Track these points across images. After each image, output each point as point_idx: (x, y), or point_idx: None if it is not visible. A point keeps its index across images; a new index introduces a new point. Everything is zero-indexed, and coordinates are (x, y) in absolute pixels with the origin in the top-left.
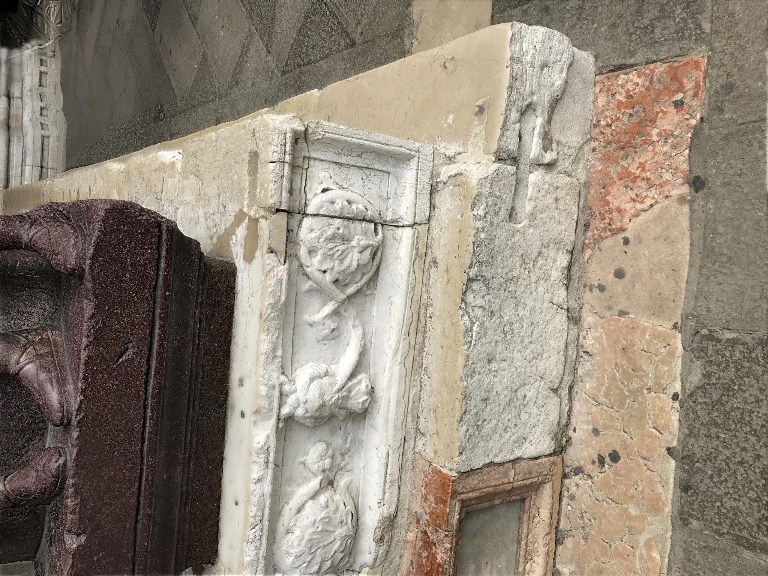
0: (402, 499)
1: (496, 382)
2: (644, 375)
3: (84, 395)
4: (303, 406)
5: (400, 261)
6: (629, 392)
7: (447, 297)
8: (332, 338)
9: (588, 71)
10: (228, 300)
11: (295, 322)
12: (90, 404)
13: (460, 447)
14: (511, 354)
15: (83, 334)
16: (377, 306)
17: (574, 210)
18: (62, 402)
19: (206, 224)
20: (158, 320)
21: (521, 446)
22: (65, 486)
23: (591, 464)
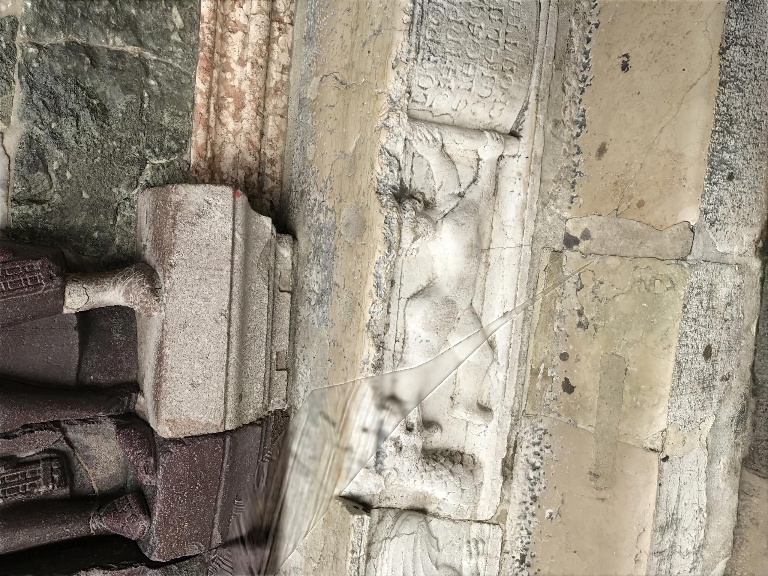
0: None
1: None
2: None
3: None
4: None
5: None
6: None
7: None
8: None
9: None
10: None
11: None
12: None
13: None
14: None
15: None
16: None
17: None
18: None
19: (291, 568)
20: None
21: None
22: None
23: None
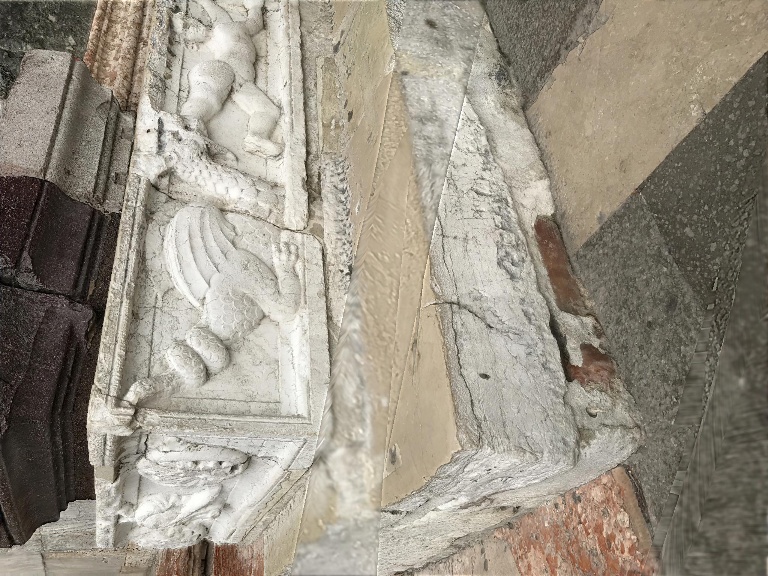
0: (247, 539)
1: None
2: None
3: None
4: None
5: (268, 475)
6: None
7: (297, 523)
8: None
9: (604, 463)
10: None
11: (141, 483)
12: None
13: None
14: None
15: None
16: (240, 480)
17: (494, 522)
18: None
19: None
20: None
21: None
22: None
23: None
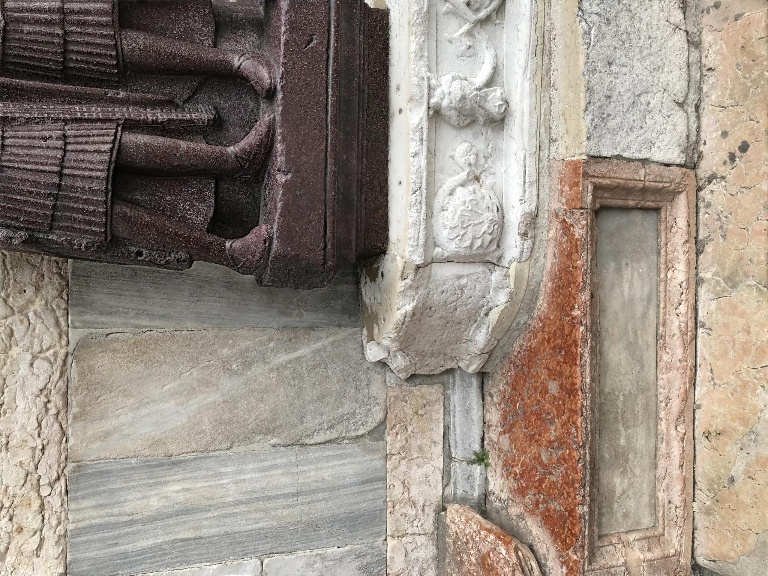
0: (541, 201)
1: (618, 83)
2: (764, 59)
3: (284, 68)
4: (448, 97)
5: None
6: (751, 82)
7: (566, 13)
8: (469, 56)
9: None
10: (384, 34)
11: (437, 37)
12: (289, 76)
13: (587, 133)
14: (631, 62)
15: (282, 24)
16: (506, 33)
17: None
18: (270, 74)
19: None
20: (333, 22)
21: (649, 149)
22: (275, 139)
23: (723, 165)
